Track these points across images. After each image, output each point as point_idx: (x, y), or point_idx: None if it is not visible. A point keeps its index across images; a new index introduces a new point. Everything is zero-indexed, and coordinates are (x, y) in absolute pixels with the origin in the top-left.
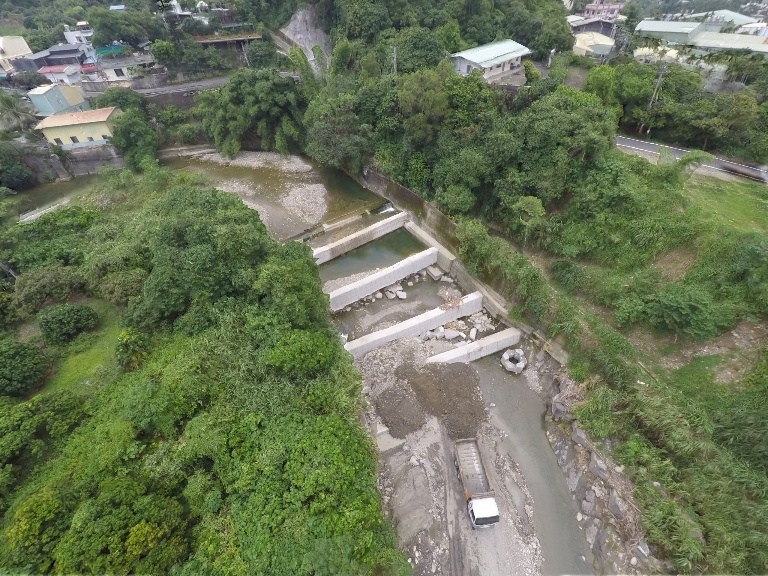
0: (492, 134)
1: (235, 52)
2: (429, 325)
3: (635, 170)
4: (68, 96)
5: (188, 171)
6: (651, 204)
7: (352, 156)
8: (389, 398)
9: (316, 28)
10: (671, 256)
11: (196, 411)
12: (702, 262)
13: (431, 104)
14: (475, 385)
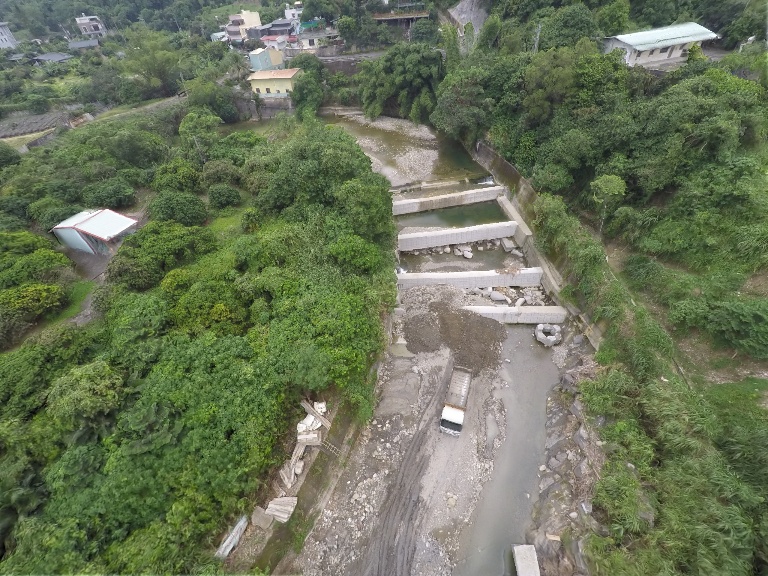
0: (610, 116)
1: (403, 29)
2: (479, 282)
3: None
4: (273, 58)
5: None
6: None
7: (466, 125)
8: (417, 322)
9: (480, 8)
10: None
11: None
12: None
13: (554, 81)
14: (499, 340)
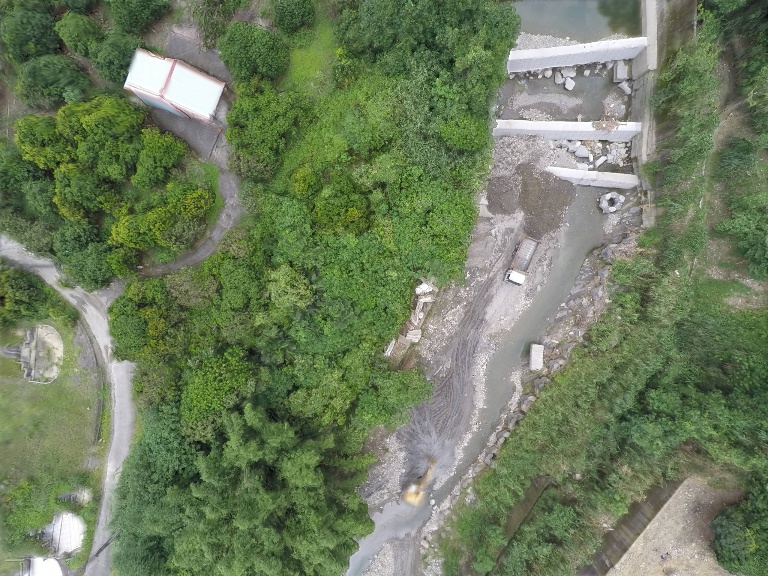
0: None
1: None
2: (571, 135)
3: None
4: None
5: None
6: None
7: None
8: (501, 184)
9: None
10: None
11: (382, 146)
12: None
13: None
14: (567, 205)
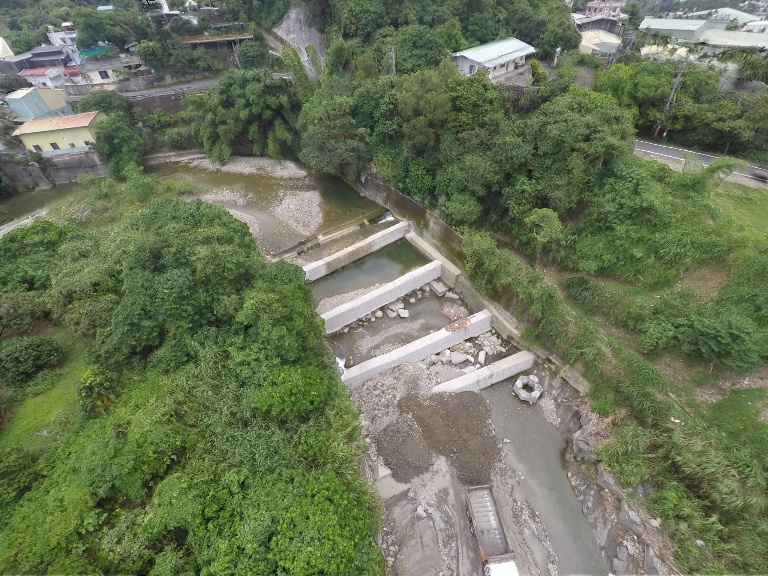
0: (499, 139)
1: (226, 53)
2: (434, 348)
3: (656, 177)
4: (48, 100)
5: (176, 178)
6: (676, 215)
7: (349, 162)
8: (392, 435)
9: (310, 27)
10: (700, 273)
11: (169, 467)
12: (737, 281)
13: (433, 107)
14: (486, 417)
